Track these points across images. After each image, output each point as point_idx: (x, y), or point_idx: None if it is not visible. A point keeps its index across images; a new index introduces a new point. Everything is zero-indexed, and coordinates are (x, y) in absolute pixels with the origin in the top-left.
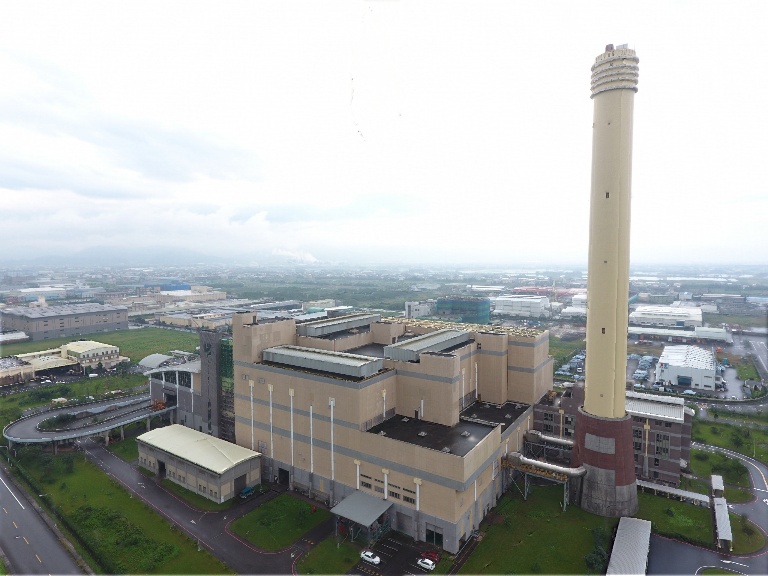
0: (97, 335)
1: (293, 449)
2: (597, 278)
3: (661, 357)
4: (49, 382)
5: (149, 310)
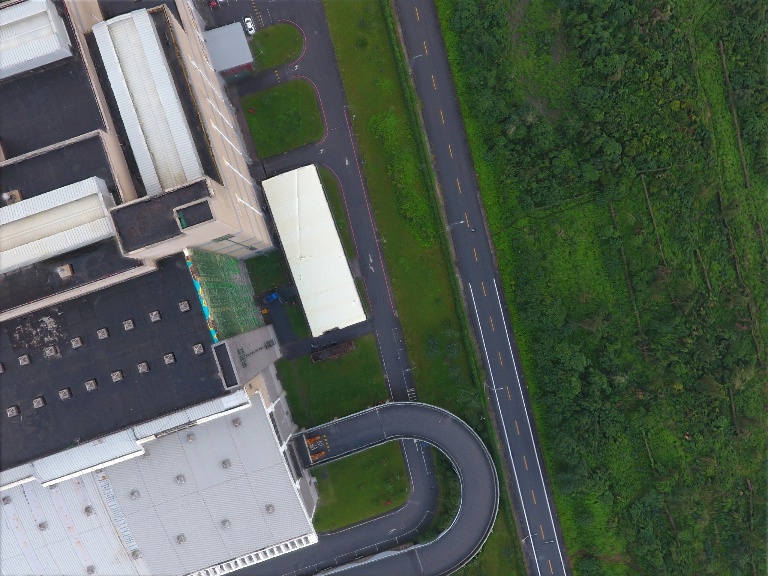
0: None
1: (235, 147)
2: None
3: None
4: None
5: None
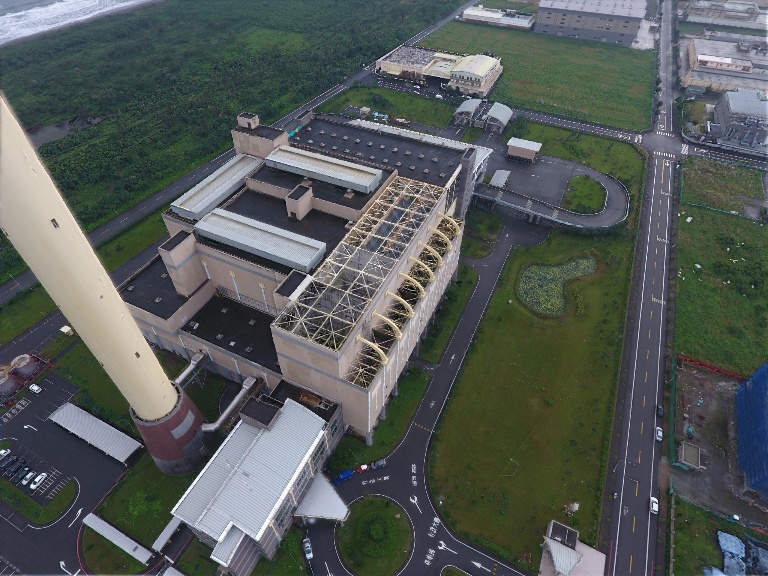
0: (582, 44)
1: None
2: None
3: None
4: (418, 88)
5: (727, 19)
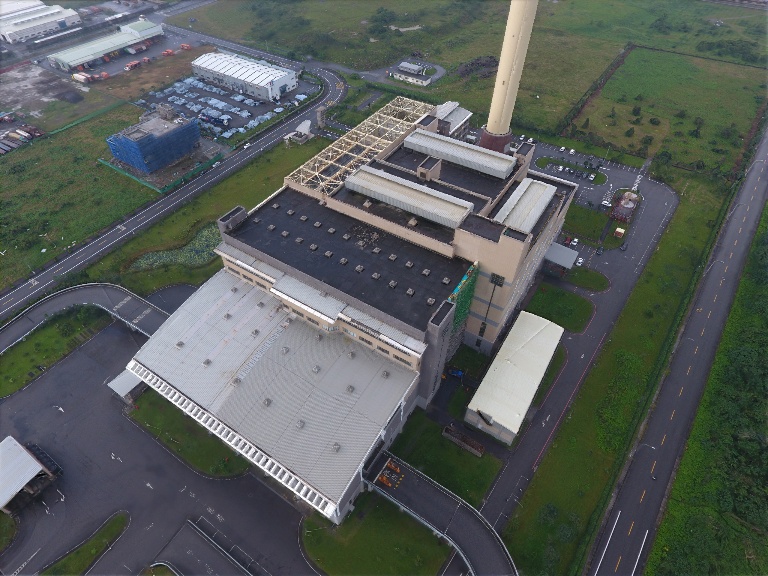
0: None
1: None
2: (525, 47)
3: (235, 76)
4: None
5: None
